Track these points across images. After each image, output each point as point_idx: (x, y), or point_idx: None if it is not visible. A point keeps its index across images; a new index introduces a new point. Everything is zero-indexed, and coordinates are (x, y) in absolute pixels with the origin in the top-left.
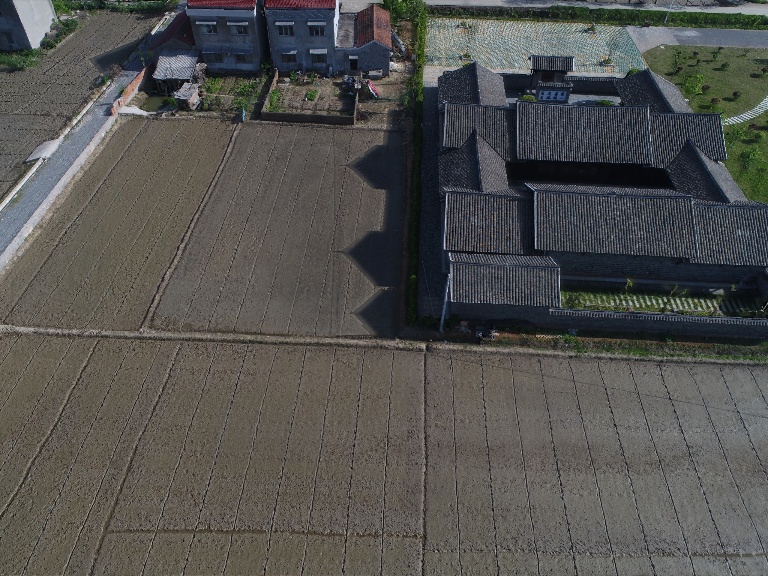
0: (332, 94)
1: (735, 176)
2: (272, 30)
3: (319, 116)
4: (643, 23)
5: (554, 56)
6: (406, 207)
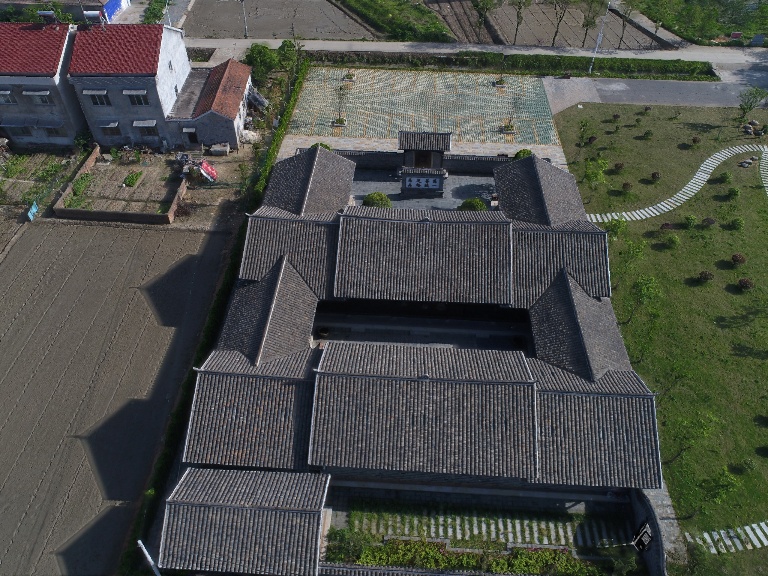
0: (159, 177)
1: (634, 302)
2: (83, 99)
3: (125, 213)
4: (564, 73)
5: (427, 132)
6: (192, 357)
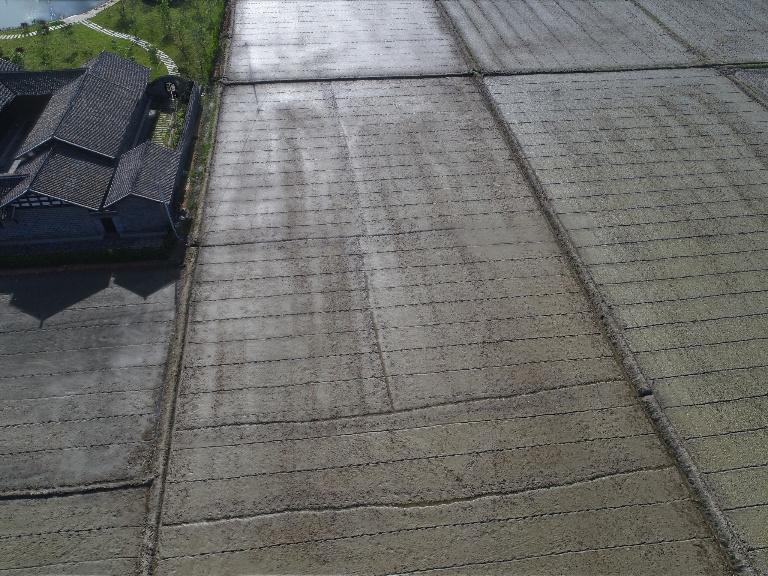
0: None
1: None
2: None
3: None
4: None
5: None
6: None
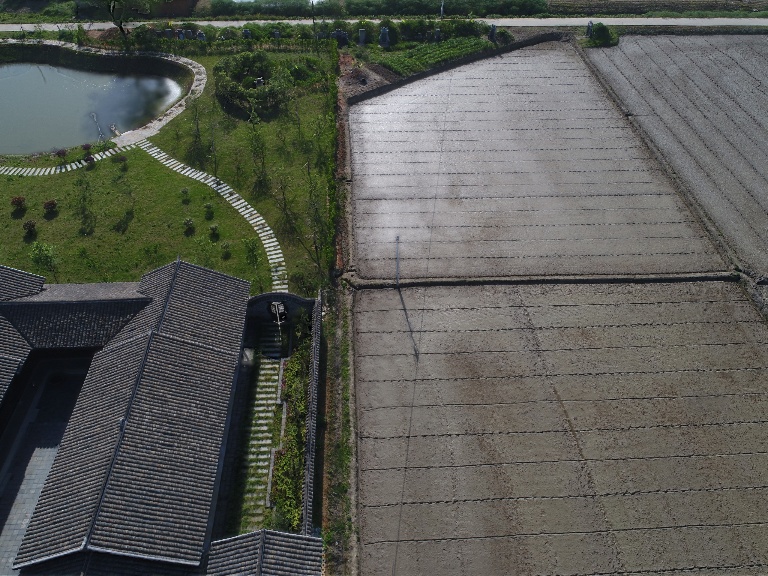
0: None
1: None
2: None
3: None
4: None
5: None
6: None
